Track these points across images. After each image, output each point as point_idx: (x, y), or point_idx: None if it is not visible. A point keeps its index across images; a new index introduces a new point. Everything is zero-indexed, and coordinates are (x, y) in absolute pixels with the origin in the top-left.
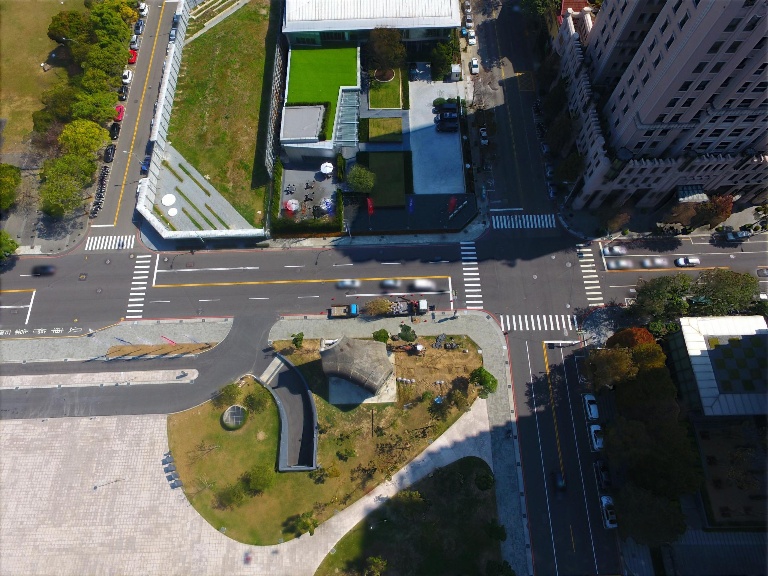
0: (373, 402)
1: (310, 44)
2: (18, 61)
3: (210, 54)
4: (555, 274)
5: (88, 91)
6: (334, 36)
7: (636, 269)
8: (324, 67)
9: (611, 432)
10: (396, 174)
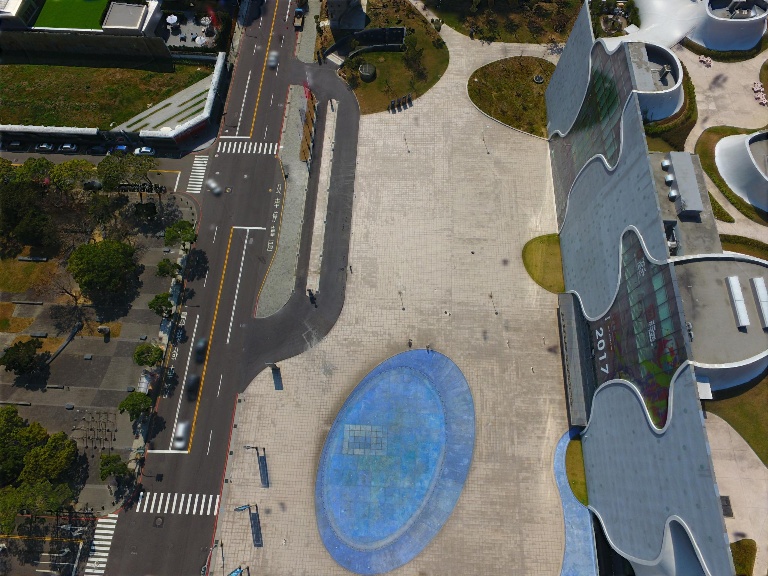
0: (366, 8)
1: (32, 14)
2: None
3: None
4: None
5: None
6: None
7: None
8: (65, 6)
9: None
10: None
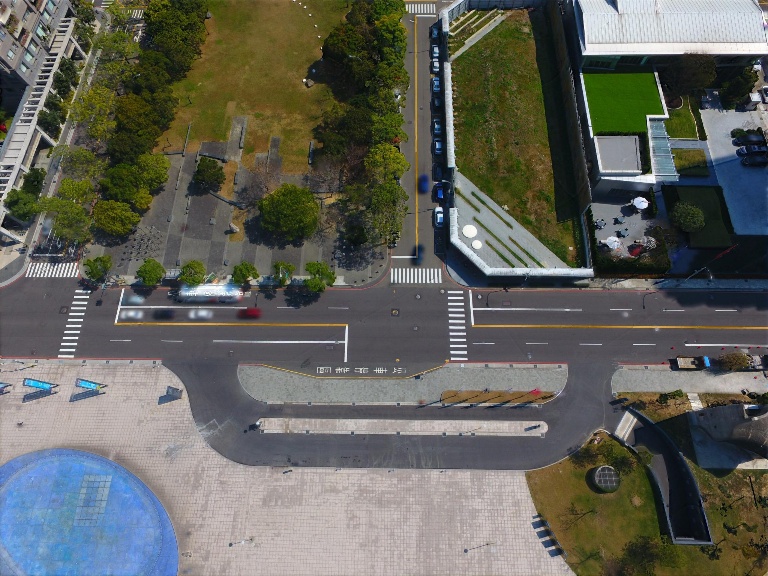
0: (748, 468)
1: (602, 67)
2: (278, 76)
3: (482, 74)
4: None
5: (376, 112)
6: (629, 60)
7: None
8: (623, 93)
9: None
10: (713, 212)
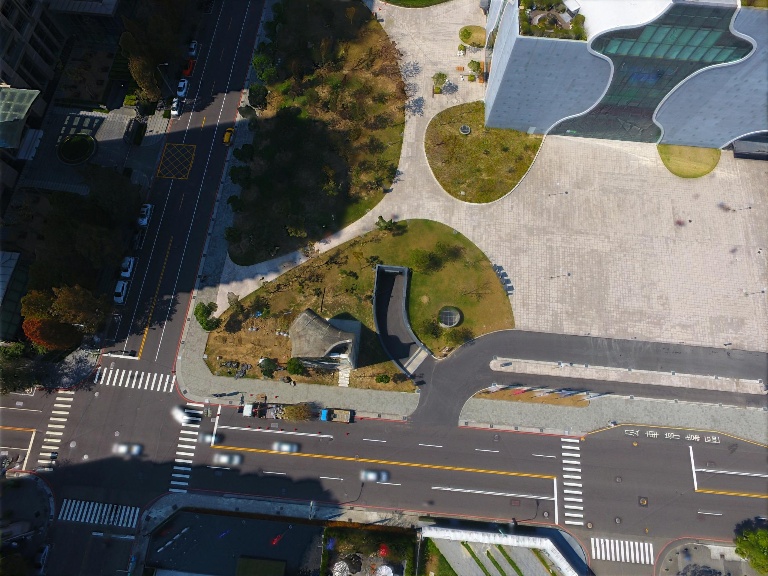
0: None
1: None
2: None
3: None
4: (93, 434)
5: None
6: None
7: (2, 429)
8: None
9: (108, 249)
10: None
